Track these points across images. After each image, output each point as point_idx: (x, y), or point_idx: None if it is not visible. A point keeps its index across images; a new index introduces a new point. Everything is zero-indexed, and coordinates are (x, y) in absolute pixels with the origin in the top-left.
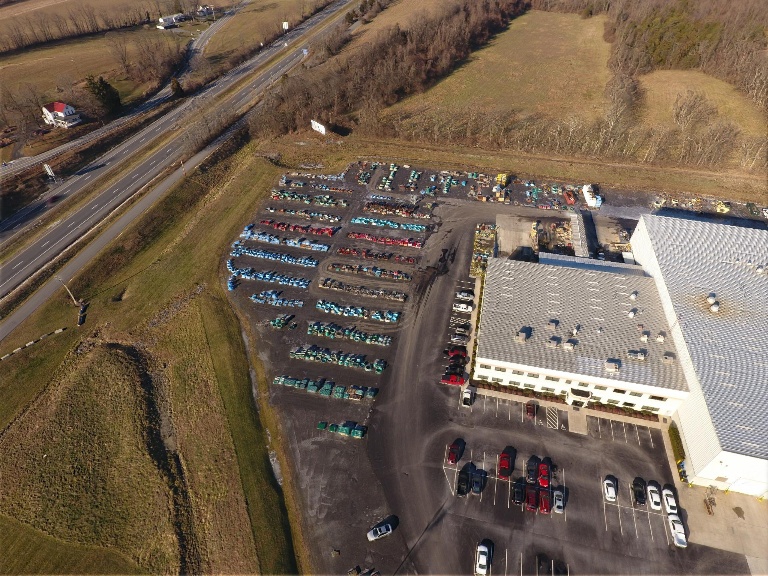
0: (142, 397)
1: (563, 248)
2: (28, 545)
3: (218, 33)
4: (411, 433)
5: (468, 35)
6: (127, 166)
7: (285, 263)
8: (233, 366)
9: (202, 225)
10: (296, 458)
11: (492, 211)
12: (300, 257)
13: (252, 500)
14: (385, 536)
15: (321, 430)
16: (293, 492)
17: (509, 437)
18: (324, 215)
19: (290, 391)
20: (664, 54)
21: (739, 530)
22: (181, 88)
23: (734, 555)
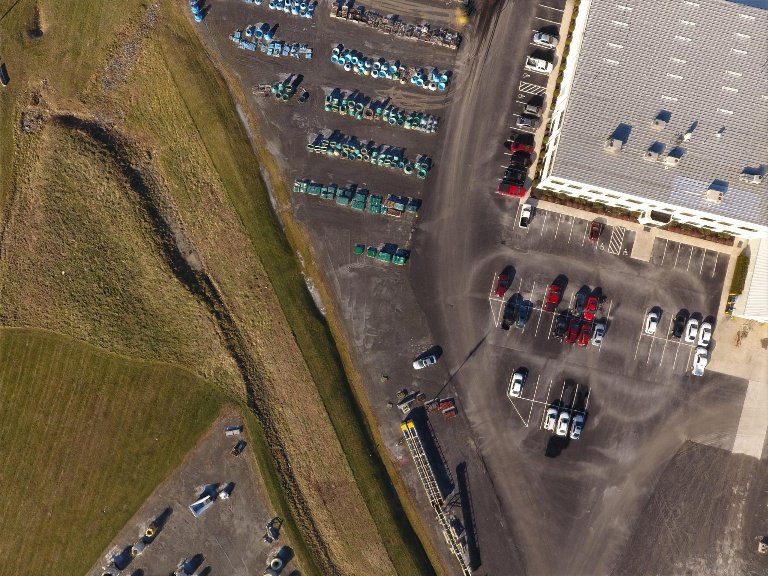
0: (140, 204)
1: None
2: (96, 360)
3: None
4: (458, 259)
5: None
6: None
7: None
8: (238, 165)
9: None
10: (335, 287)
11: None
12: None
13: (298, 332)
14: (429, 365)
15: (358, 255)
16: (337, 322)
17: (564, 264)
18: None
19: (316, 202)
20: None
21: (756, 359)
22: None
23: (740, 380)
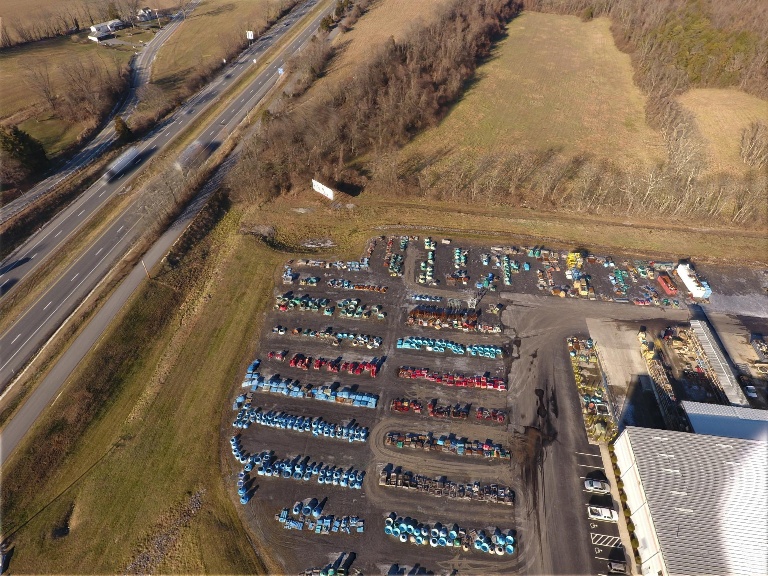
0: None
1: (694, 377)
2: None
3: (167, 45)
4: None
5: (474, 49)
6: (62, 259)
7: (319, 437)
8: None
9: (182, 364)
10: None
11: (578, 314)
12: (339, 422)
13: None
14: None
15: None
16: None
17: None
18: (357, 336)
19: None
20: (698, 70)
21: None
22: (128, 129)
23: None
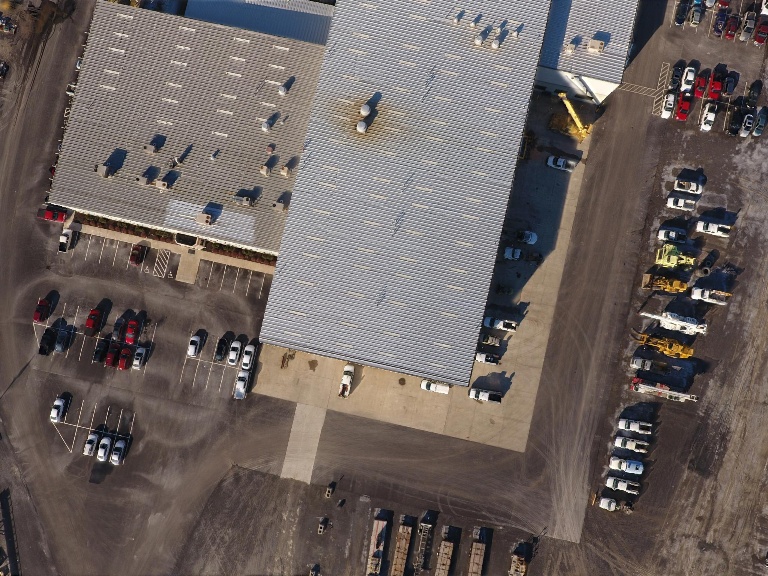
0: None
1: None
2: None
3: None
4: (2, 285)
5: None
6: None
7: None
8: None
9: None
10: None
11: None
12: None
13: None
14: None
15: None
16: None
17: (108, 288)
18: None
19: None
20: None
21: (303, 381)
22: None
23: (287, 403)
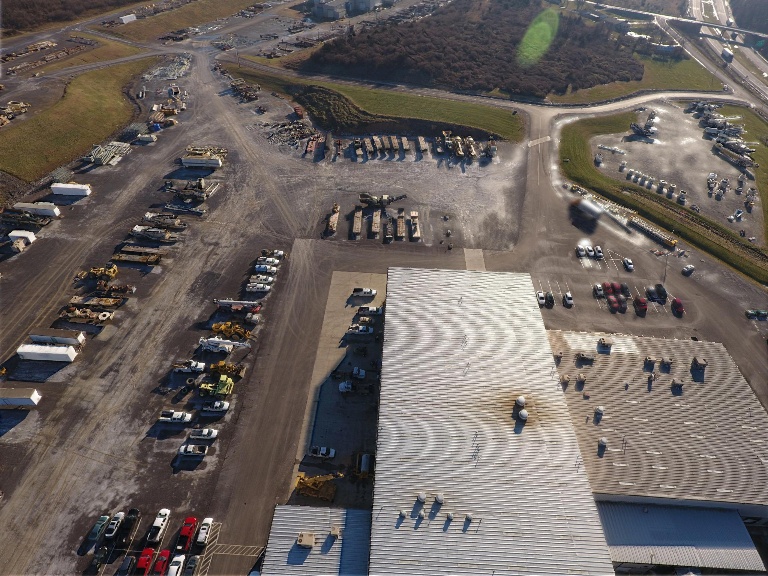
0: None
1: None
2: None
3: None
4: (716, 318)
5: None
6: None
7: None
8: None
9: None
10: None
11: None
12: None
13: None
14: None
15: None
16: (753, 282)
17: (647, 323)
18: None
19: None
20: None
21: None
22: None
23: None
